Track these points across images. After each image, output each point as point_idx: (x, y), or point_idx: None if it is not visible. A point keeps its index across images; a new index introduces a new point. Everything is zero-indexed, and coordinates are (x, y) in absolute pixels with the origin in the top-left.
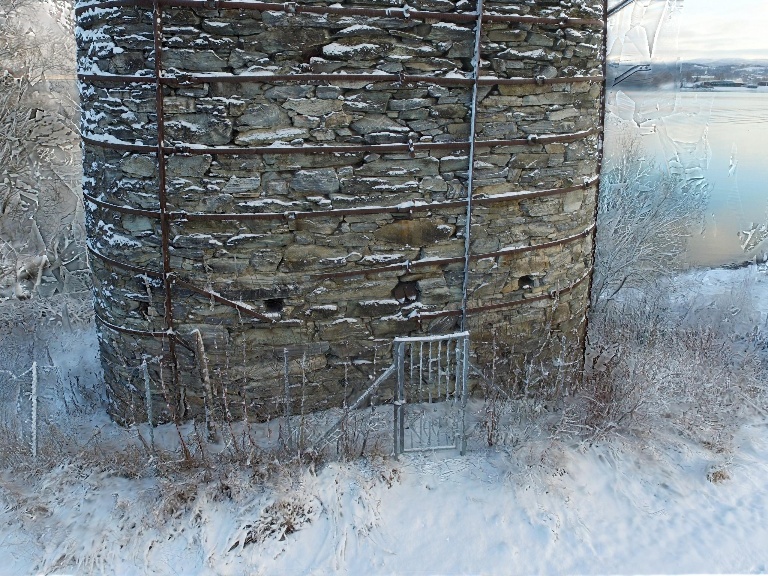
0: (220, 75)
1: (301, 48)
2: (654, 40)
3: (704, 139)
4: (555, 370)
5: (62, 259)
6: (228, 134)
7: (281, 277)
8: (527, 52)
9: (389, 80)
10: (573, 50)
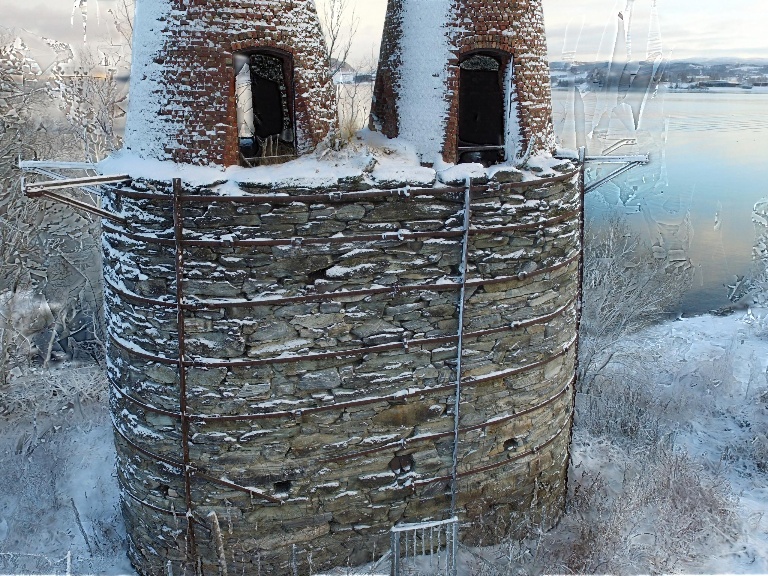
0: (235, 301)
1: (307, 273)
2: (641, 106)
3: (686, 222)
4: (536, 537)
5: (70, 329)
6: (242, 349)
7: (289, 463)
8: (509, 254)
9: (385, 291)
10: (552, 244)
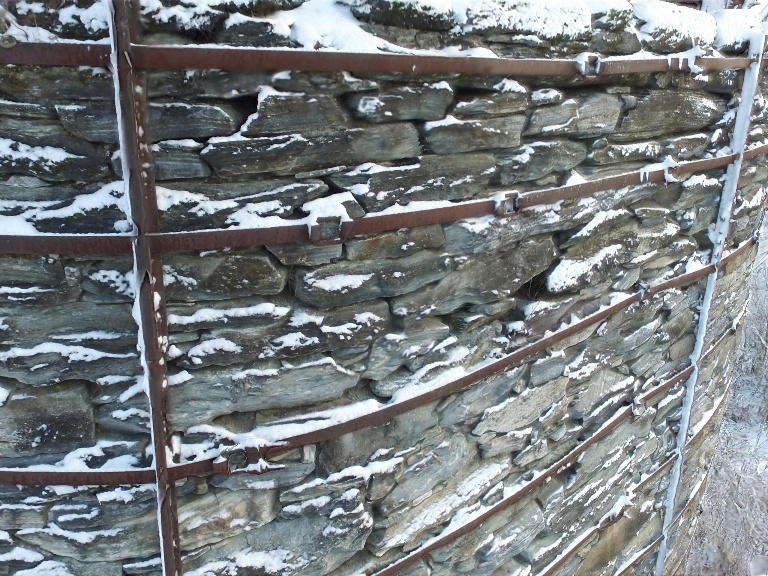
0: (349, 416)
1: (512, 291)
2: None
3: None
4: None
5: None
6: (361, 544)
7: None
8: (753, 199)
9: None
10: None
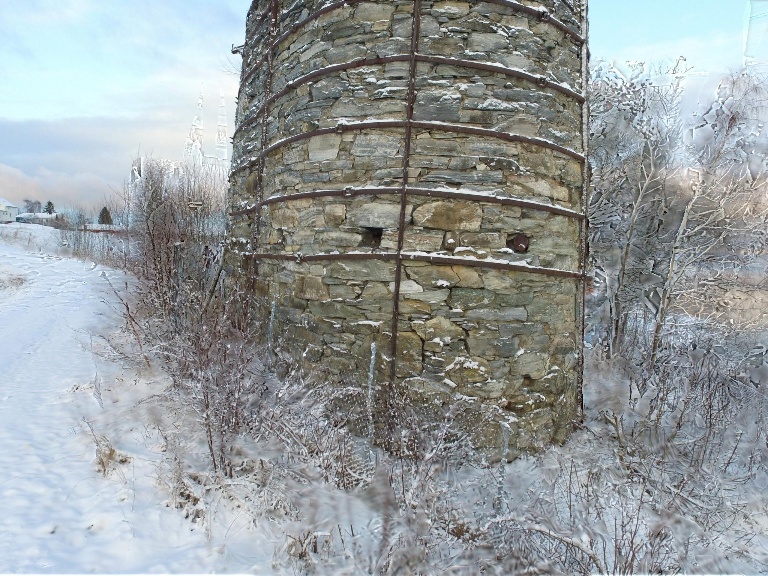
0: None
1: None
2: None
3: None
4: None
5: None
6: None
7: None
8: None
9: None
10: None
